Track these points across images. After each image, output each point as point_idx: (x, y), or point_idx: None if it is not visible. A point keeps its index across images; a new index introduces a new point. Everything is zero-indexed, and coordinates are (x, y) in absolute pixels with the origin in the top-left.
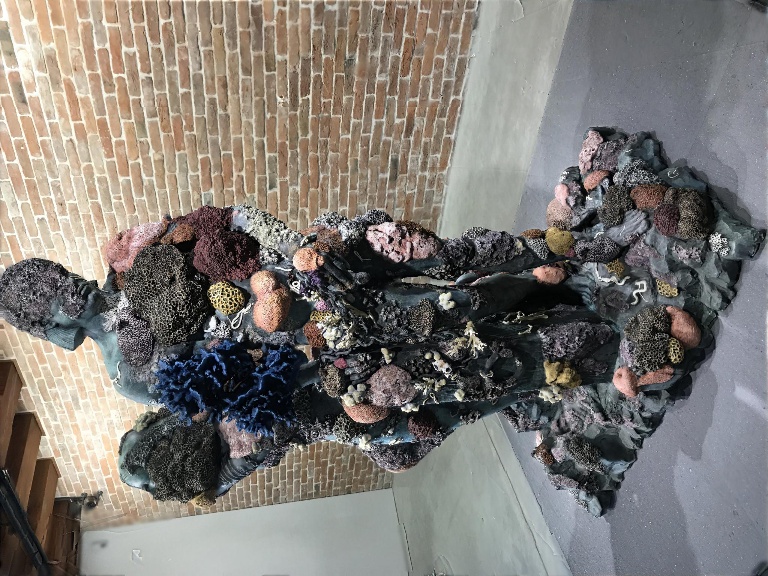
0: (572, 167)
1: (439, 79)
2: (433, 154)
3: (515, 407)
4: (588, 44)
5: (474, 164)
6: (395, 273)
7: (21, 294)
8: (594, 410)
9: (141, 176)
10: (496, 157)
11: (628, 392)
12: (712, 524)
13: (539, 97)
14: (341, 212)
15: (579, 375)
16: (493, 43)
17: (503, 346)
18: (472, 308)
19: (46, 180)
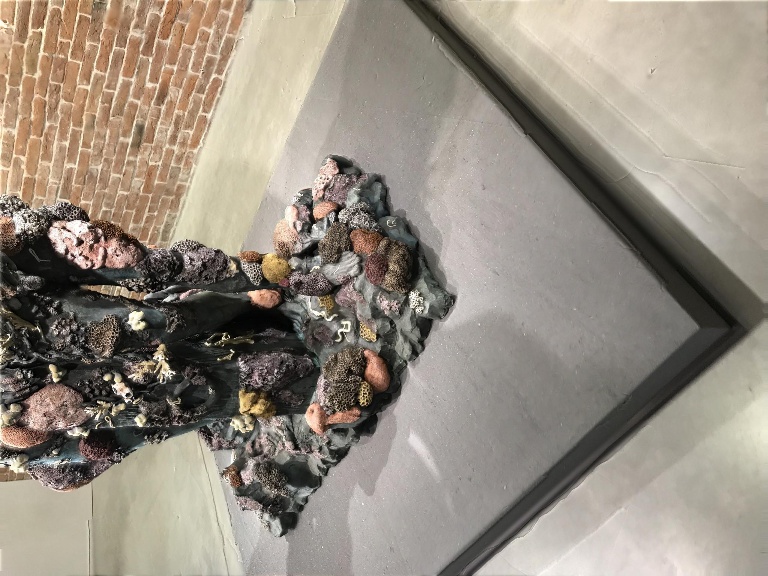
0: (307, 189)
1: (202, 52)
2: (185, 129)
3: (211, 426)
4: (343, 69)
5: (226, 151)
6: (82, 279)
7: None
8: (286, 438)
9: None
10: (247, 151)
11: (316, 430)
12: (372, 557)
13: (296, 103)
14: (68, 170)
15: (274, 406)
16: (263, 32)
17: (197, 372)
18: (166, 331)
19: None
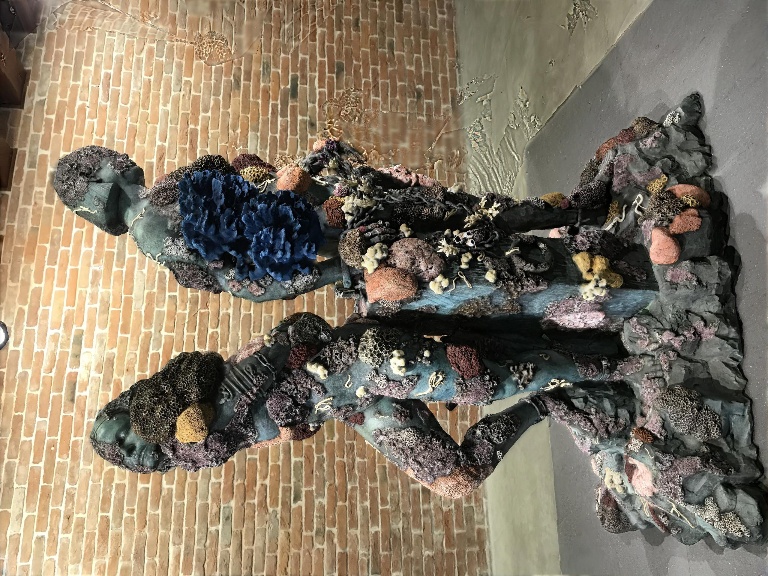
0: None
1: None
2: None
3: (581, 402)
4: None
5: None
6: None
7: (81, 151)
8: (660, 333)
9: (161, 484)
10: None
11: (665, 241)
12: None
13: None
14: (373, 536)
15: None
16: None
17: None
18: (480, 199)
19: (63, 486)
